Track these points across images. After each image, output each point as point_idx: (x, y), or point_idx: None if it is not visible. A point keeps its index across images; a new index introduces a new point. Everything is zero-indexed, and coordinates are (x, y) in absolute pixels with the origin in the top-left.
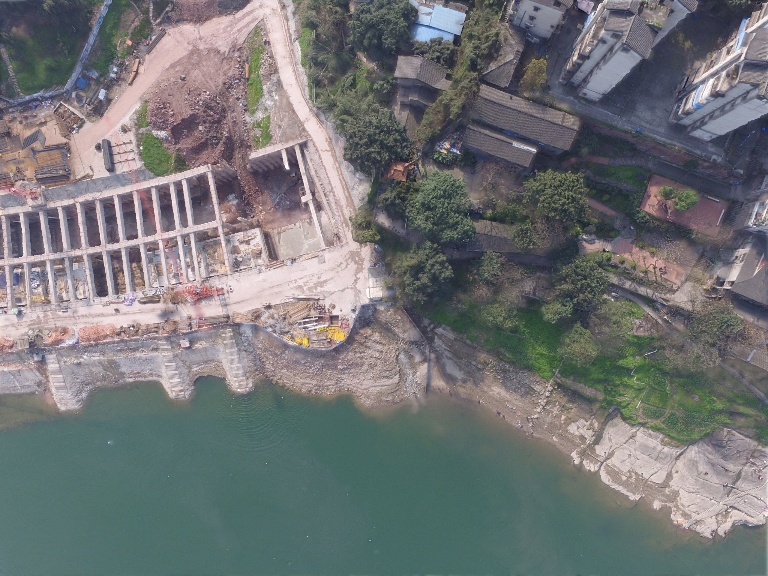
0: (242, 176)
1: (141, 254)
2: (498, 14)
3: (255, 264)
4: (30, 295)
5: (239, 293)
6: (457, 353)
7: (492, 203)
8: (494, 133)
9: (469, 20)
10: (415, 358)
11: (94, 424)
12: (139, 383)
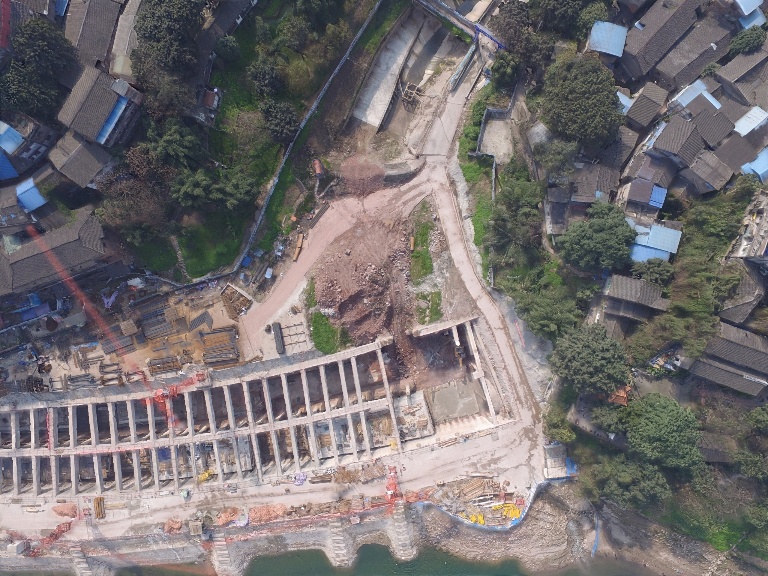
0: (399, 339)
1: (310, 433)
2: (727, 244)
3: (421, 435)
4: (196, 475)
5: (412, 471)
6: (627, 522)
7: (704, 417)
8: (723, 364)
9: (705, 258)
10: (583, 526)
11: None
12: (300, 551)
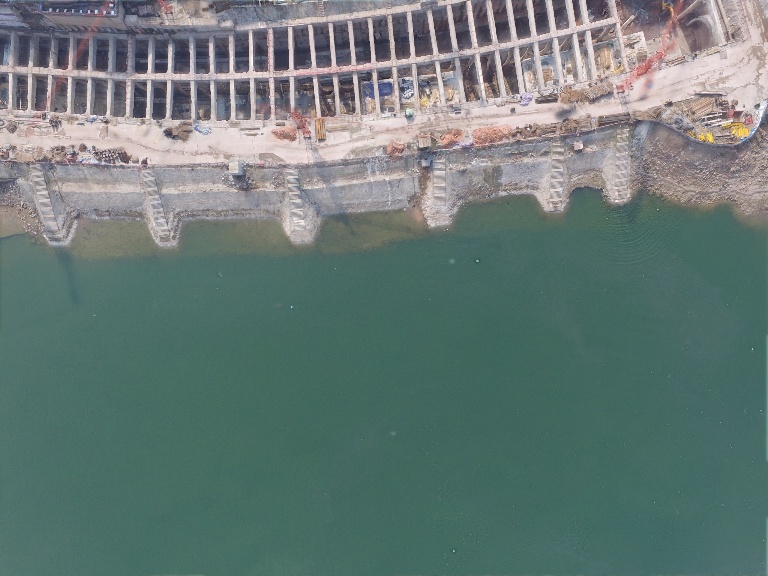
0: None
1: (536, 53)
2: None
3: None
4: None
5: (639, 91)
6: None
7: None
8: None
9: None
10: None
11: (465, 240)
12: (511, 197)
